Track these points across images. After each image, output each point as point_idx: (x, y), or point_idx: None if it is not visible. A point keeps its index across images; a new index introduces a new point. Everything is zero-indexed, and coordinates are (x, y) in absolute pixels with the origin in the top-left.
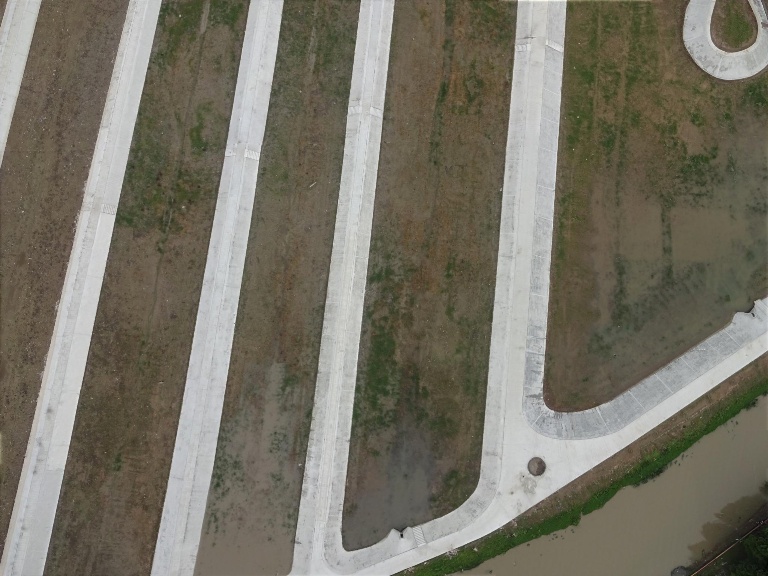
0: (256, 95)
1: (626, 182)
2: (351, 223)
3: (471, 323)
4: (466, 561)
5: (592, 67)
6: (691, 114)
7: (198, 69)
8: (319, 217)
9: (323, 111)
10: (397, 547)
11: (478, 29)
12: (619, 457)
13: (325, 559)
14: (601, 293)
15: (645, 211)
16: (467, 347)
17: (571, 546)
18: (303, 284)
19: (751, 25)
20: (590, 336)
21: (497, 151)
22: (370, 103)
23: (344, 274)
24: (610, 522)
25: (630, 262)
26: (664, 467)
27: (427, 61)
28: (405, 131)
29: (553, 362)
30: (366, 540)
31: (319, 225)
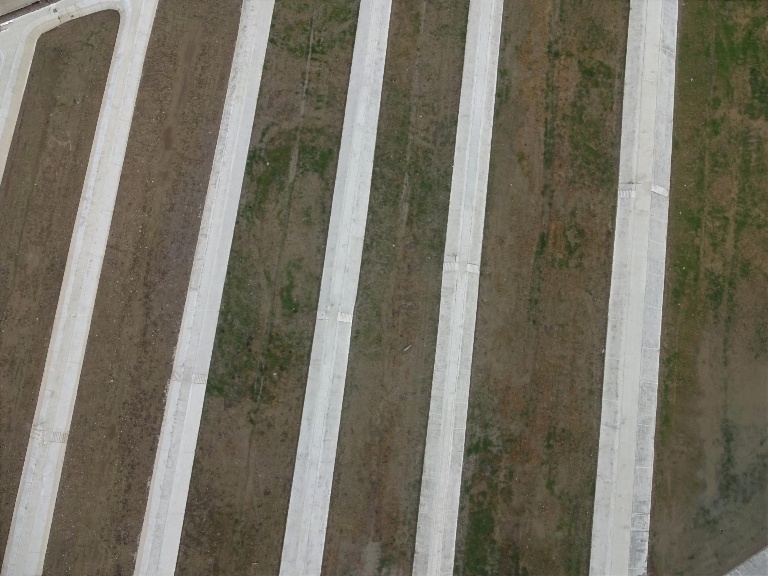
0: (348, 252)
1: (734, 339)
2: (448, 392)
3: (572, 497)
4: None
5: (699, 212)
6: None
7: (287, 222)
8: (414, 384)
9: (417, 267)
10: None
11: (579, 172)
12: None
13: None
14: (707, 462)
15: (754, 371)
16: (568, 524)
17: None
18: (398, 456)
19: None
20: (696, 510)
21: (599, 308)
22: (467, 259)
23: (442, 448)
24: None
25: (738, 428)
26: None
27: (525, 209)
28: (503, 287)
29: (657, 538)
30: None
31: (414, 392)
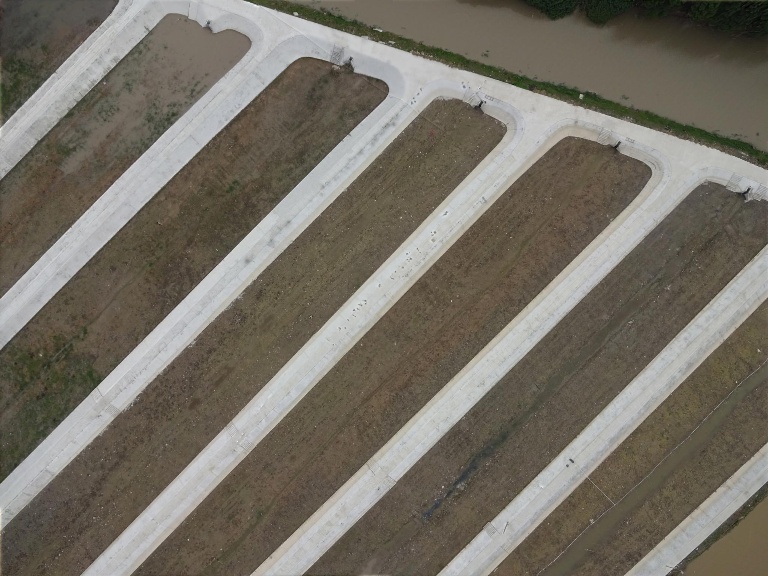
0: None
1: None
2: None
3: None
4: None
5: None
6: None
7: None
8: None
9: None
10: None
11: None
12: None
13: (133, 1)
14: None
15: None
16: None
17: None
18: None
19: None
20: None
21: None
22: None
23: None
24: None
25: None
26: None
27: None
28: None
29: None
30: None
31: None
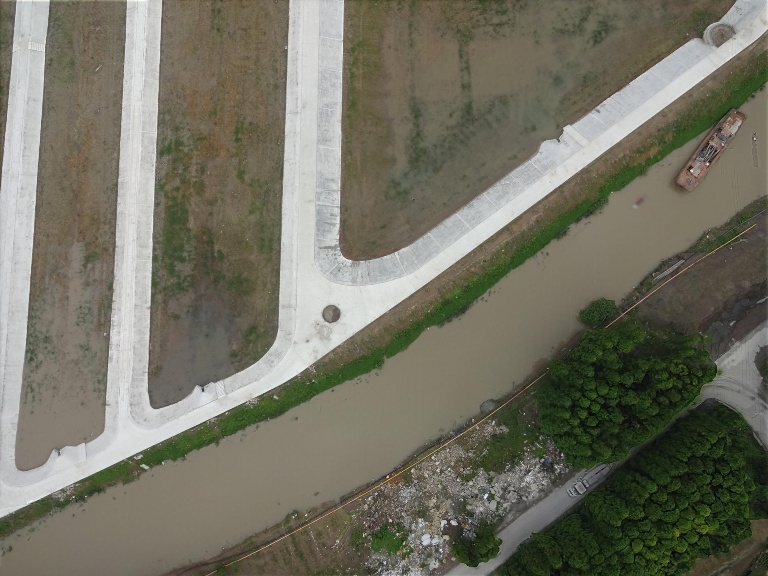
0: None
1: (419, 22)
2: (135, 100)
3: (263, 184)
4: (269, 410)
5: None
6: None
7: None
8: (107, 99)
9: None
10: (199, 401)
11: None
12: (416, 297)
13: (131, 417)
14: (397, 139)
15: (441, 49)
16: (260, 207)
17: (375, 388)
18: (96, 165)
19: None
20: (387, 183)
21: (280, 9)
22: None
23: (131, 150)
24: (415, 363)
25: (426, 104)
26: (470, 305)
27: None
28: (186, 2)
29: (349, 213)
30: (172, 398)
31: (107, 107)
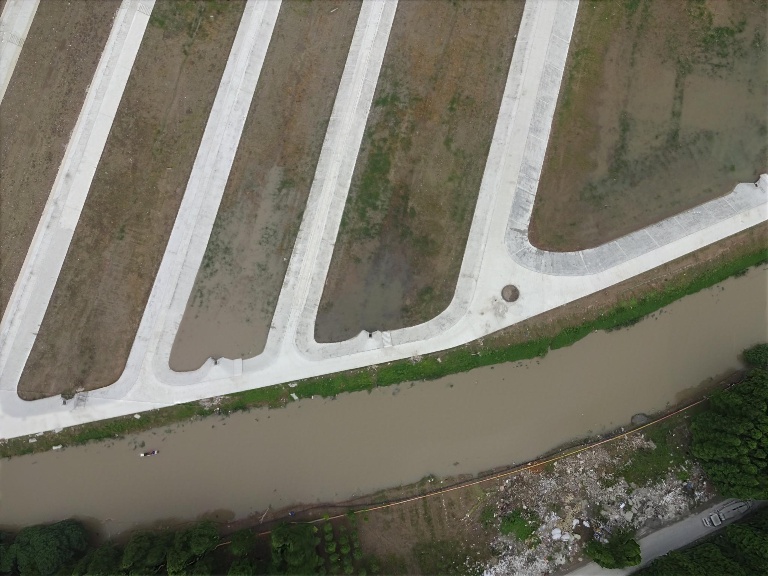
0: None
1: (644, 45)
2: (364, 47)
3: (467, 155)
4: (429, 371)
5: None
6: None
7: None
8: (336, 40)
9: None
10: (364, 345)
11: None
12: (594, 298)
13: (295, 344)
14: (601, 146)
15: (659, 74)
16: (460, 177)
17: (534, 376)
18: (312, 99)
19: None
20: (584, 184)
21: None
22: None
23: (351, 92)
24: (577, 361)
25: (636, 121)
26: (640, 318)
27: None
28: None
29: (543, 203)
30: (337, 336)
31: (334, 47)
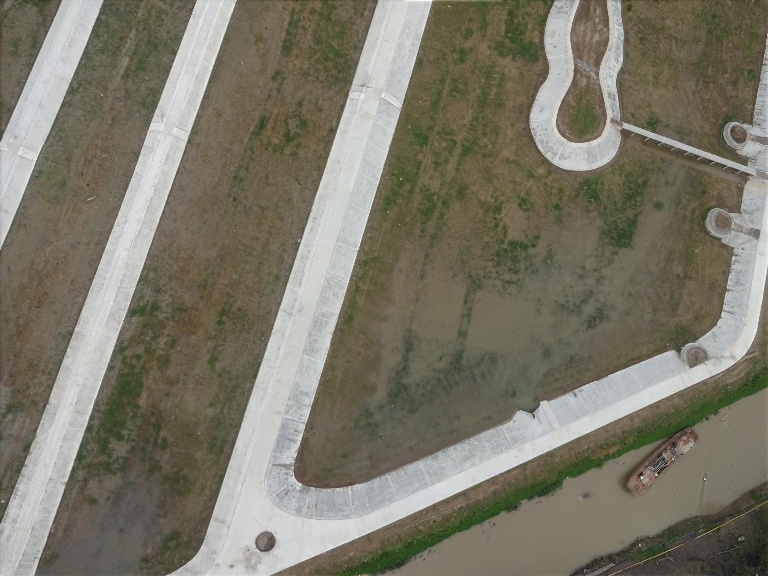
0: (48, 90)
1: (436, 256)
2: (122, 248)
3: (233, 377)
4: None
5: (428, 129)
6: (520, 197)
7: None
8: (90, 235)
9: (122, 121)
10: None
11: (315, 66)
12: (357, 544)
13: None
14: (382, 367)
15: (449, 289)
16: (223, 402)
17: None
18: (55, 304)
19: (600, 118)
20: (360, 410)
21: (305, 199)
22: (175, 122)
23: (101, 302)
24: None
25: (421, 340)
26: (407, 560)
27: (251, 89)
28: (209, 159)
29: (314, 432)
30: None
31: (88, 243)
